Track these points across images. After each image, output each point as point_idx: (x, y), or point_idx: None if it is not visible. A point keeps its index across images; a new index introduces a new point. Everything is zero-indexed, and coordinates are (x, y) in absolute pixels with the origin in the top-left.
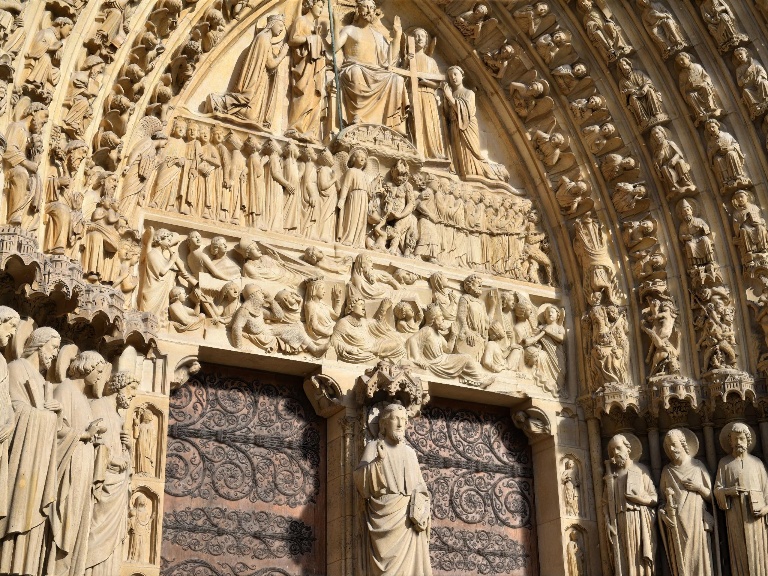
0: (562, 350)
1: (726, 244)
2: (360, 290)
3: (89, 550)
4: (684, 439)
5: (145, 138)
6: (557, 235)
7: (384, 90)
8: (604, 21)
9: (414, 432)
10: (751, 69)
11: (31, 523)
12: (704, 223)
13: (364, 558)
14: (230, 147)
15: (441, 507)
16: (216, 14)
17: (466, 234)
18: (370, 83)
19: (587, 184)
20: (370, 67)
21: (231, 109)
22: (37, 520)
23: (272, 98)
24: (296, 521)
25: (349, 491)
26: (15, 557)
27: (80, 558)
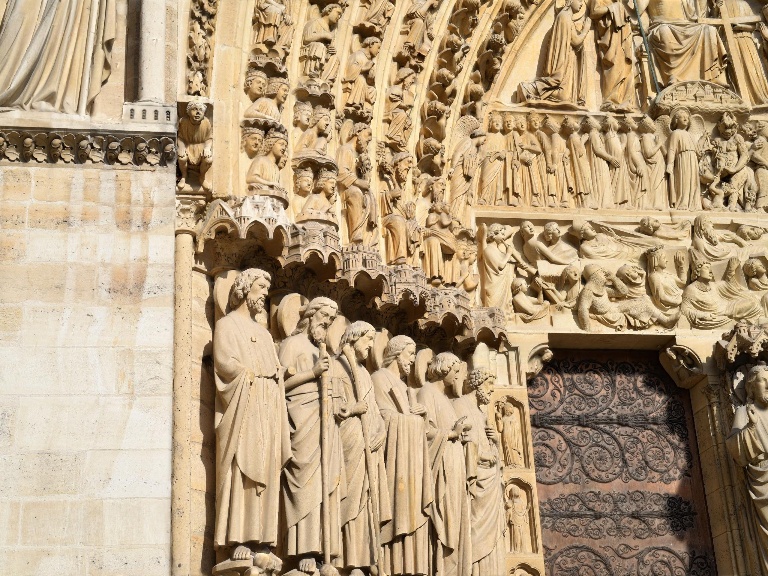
0: None
1: None
2: (704, 253)
3: (473, 545)
4: None
5: (464, 138)
6: None
7: (697, 44)
8: None
9: None
10: None
11: (415, 524)
12: None
13: (751, 528)
14: (548, 132)
15: None
16: (514, 3)
17: None
18: (681, 40)
19: None
20: (678, 23)
21: (543, 94)
22: (420, 521)
23: (582, 75)
24: (673, 497)
25: (724, 461)
26: (405, 558)
27: (466, 553)
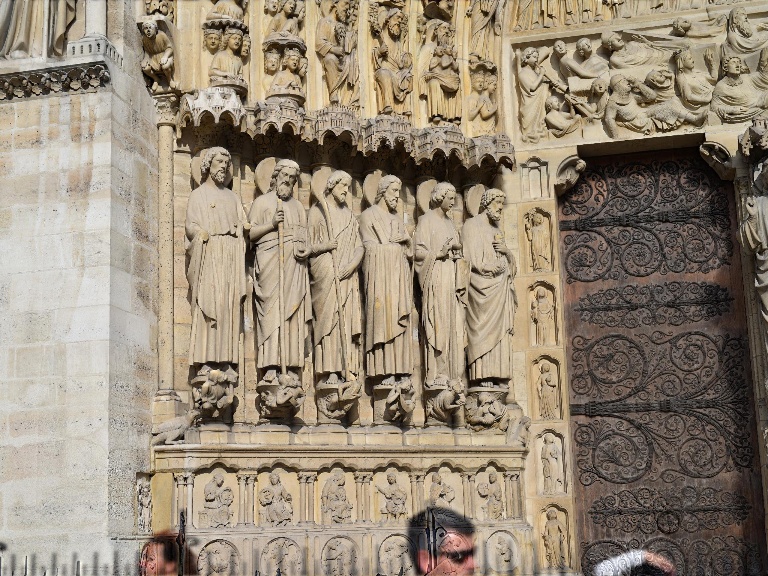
0: None
1: None
2: (736, 47)
3: (476, 344)
4: None
5: None
6: None
7: None
8: None
9: None
10: None
11: (391, 334)
12: None
13: (761, 313)
14: None
15: None
16: None
17: None
18: None
19: None
20: None
21: None
22: (397, 331)
23: None
24: (711, 285)
25: None
26: (385, 361)
27: (454, 353)
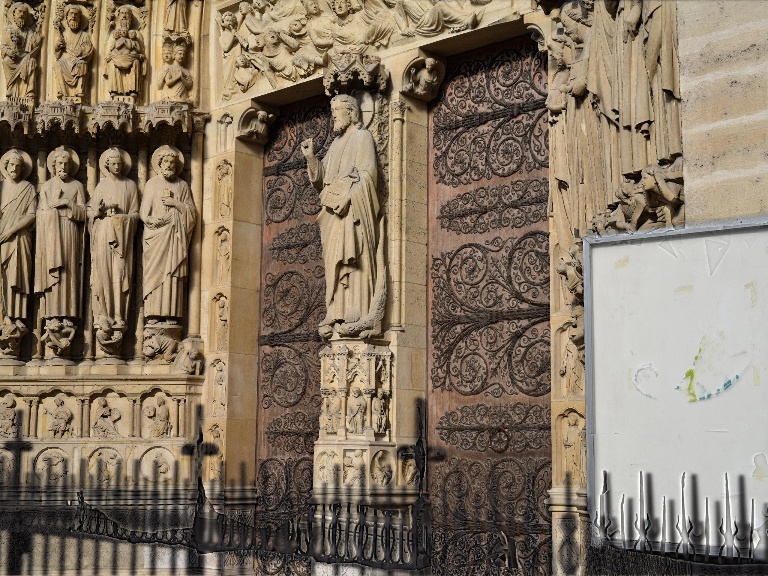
0: None
1: None
2: None
3: None
4: (574, 12)
5: None
6: None
7: None
8: None
9: (454, 97)
10: None
11: (46, 285)
12: None
13: None
14: None
15: (477, 168)
16: None
17: None
18: None
19: None
20: None
21: None
22: (52, 281)
23: None
24: None
25: None
26: None
27: None
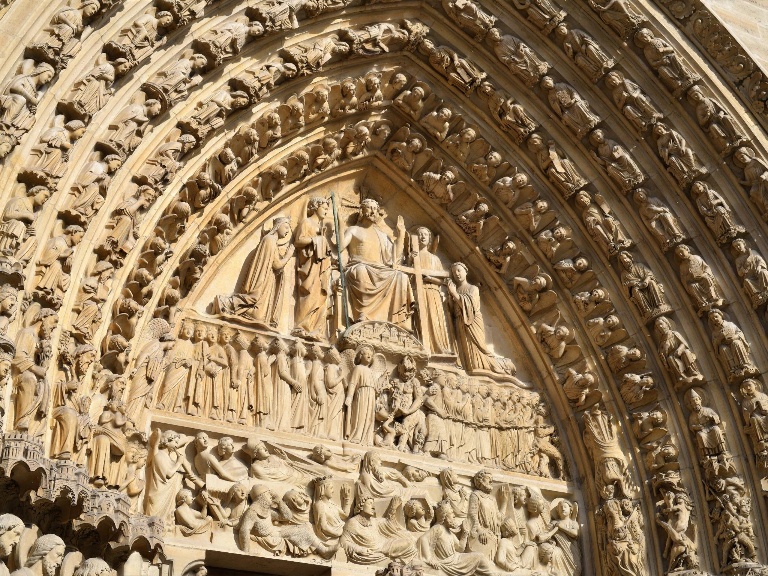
0: (577, 546)
1: (737, 433)
2: (369, 488)
3: None
4: None
5: (153, 340)
6: (566, 428)
7: (389, 288)
8: (603, 216)
9: None
10: (750, 259)
11: None
12: (714, 413)
13: None
14: (237, 347)
15: None
16: (223, 218)
17: (475, 429)
18: (375, 281)
19: (594, 376)
20: (375, 266)
21: (238, 310)
22: None
23: (279, 298)
24: None
25: None
26: None
27: None
